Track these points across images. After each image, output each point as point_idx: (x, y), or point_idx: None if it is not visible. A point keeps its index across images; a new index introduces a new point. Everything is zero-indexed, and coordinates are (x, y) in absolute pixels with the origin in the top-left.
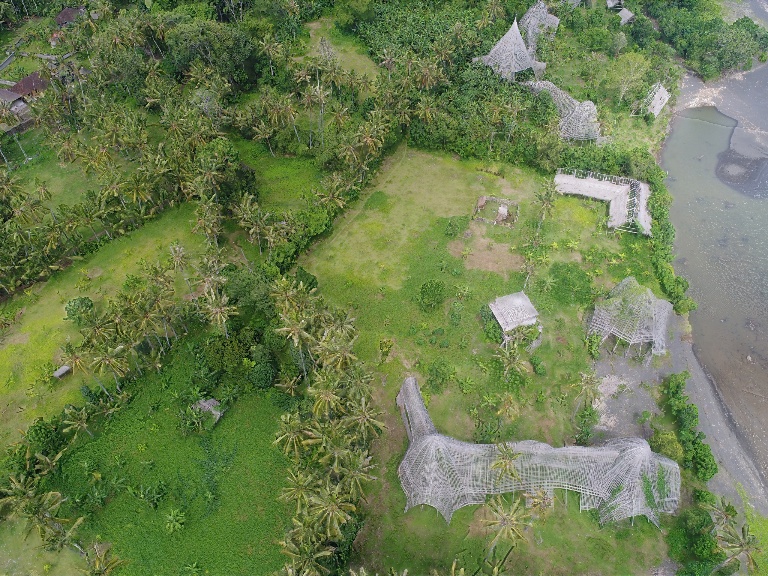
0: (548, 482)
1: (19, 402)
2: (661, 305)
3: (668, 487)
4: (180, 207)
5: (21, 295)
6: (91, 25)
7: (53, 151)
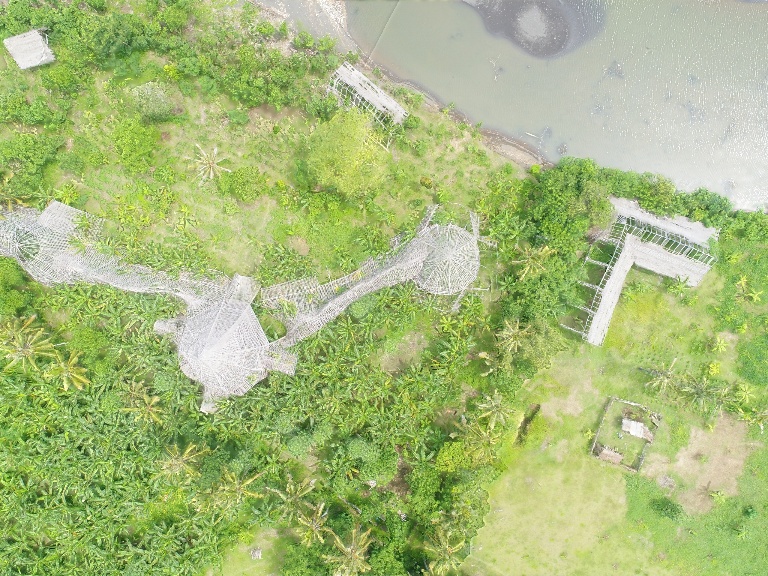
0: None
1: None
2: None
3: None
4: None
5: None
6: None
7: None
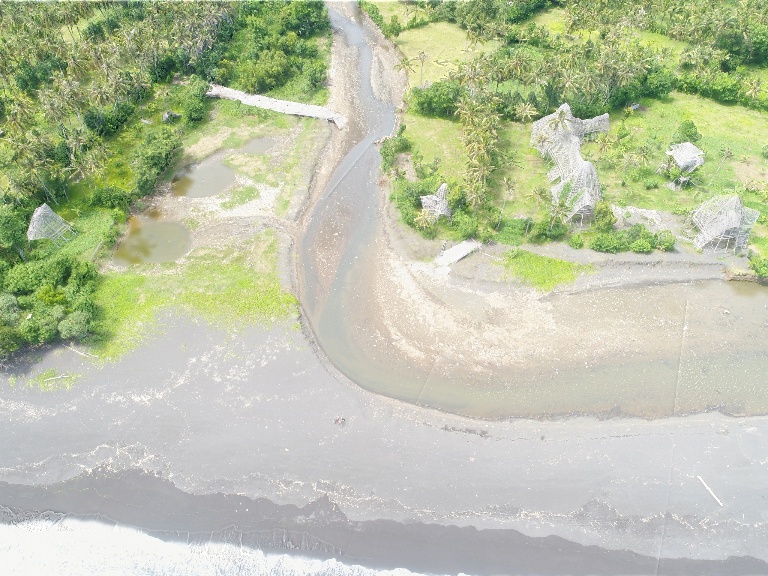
0: None
1: None
2: (731, 215)
3: (574, 206)
4: None
5: None
6: None
7: (727, 5)
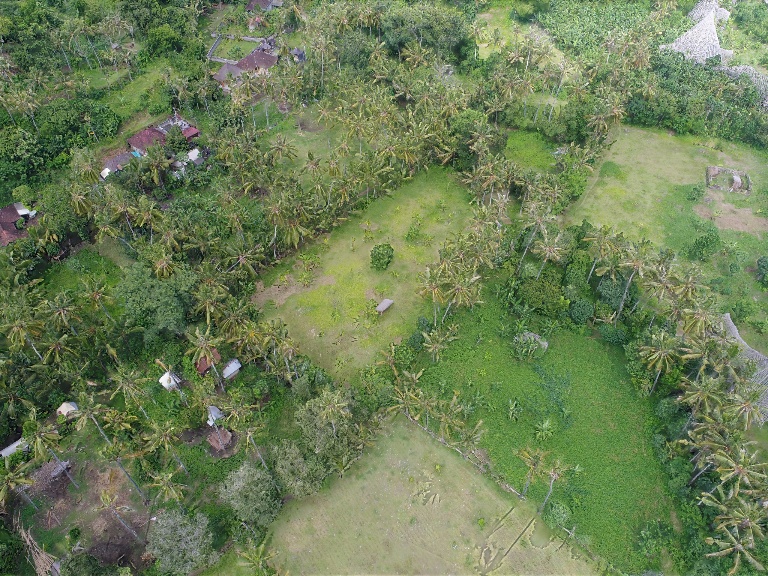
0: None
1: (350, 333)
2: None
3: None
4: (427, 172)
5: (312, 244)
6: (295, 10)
7: (287, 122)
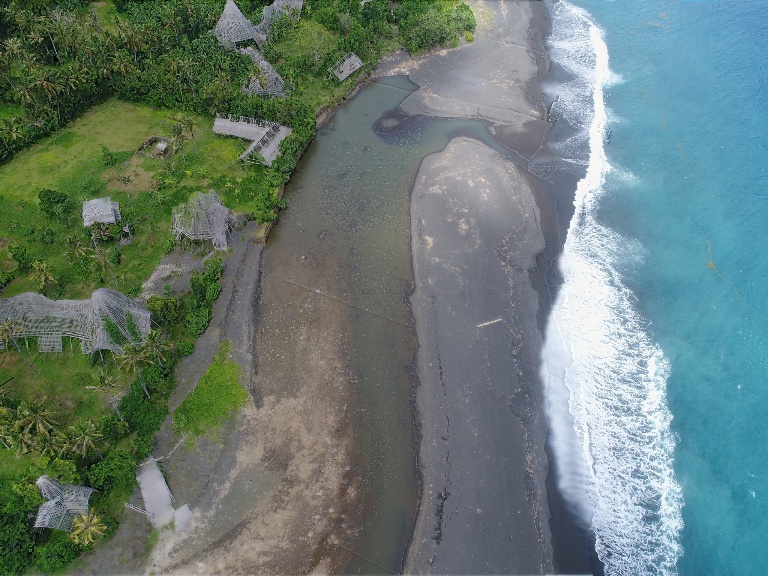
0: (56, 331)
1: None
2: (214, 207)
3: (140, 332)
4: None
5: None
6: None
7: None
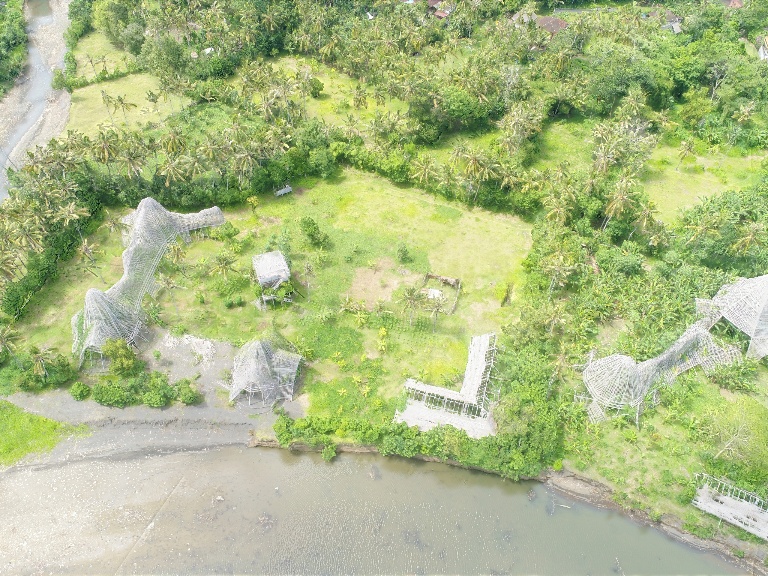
0: None
1: None
2: (251, 365)
3: None
4: None
5: (339, 73)
6: None
7: None
